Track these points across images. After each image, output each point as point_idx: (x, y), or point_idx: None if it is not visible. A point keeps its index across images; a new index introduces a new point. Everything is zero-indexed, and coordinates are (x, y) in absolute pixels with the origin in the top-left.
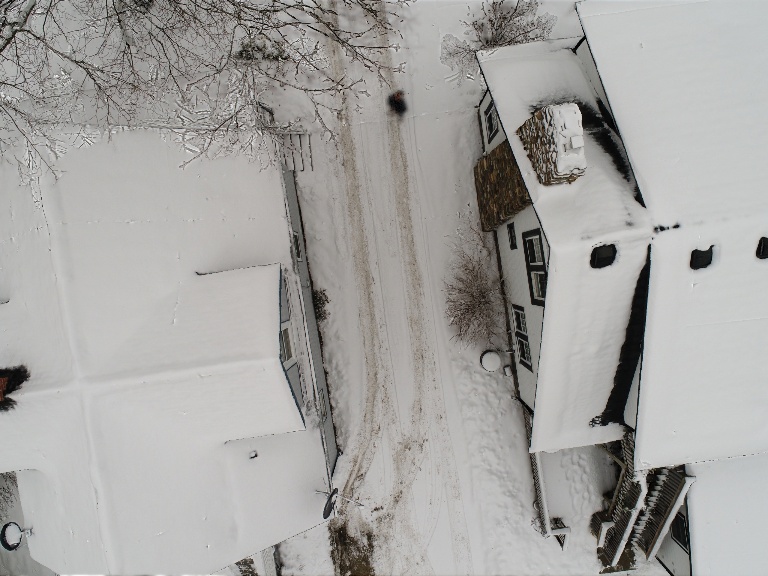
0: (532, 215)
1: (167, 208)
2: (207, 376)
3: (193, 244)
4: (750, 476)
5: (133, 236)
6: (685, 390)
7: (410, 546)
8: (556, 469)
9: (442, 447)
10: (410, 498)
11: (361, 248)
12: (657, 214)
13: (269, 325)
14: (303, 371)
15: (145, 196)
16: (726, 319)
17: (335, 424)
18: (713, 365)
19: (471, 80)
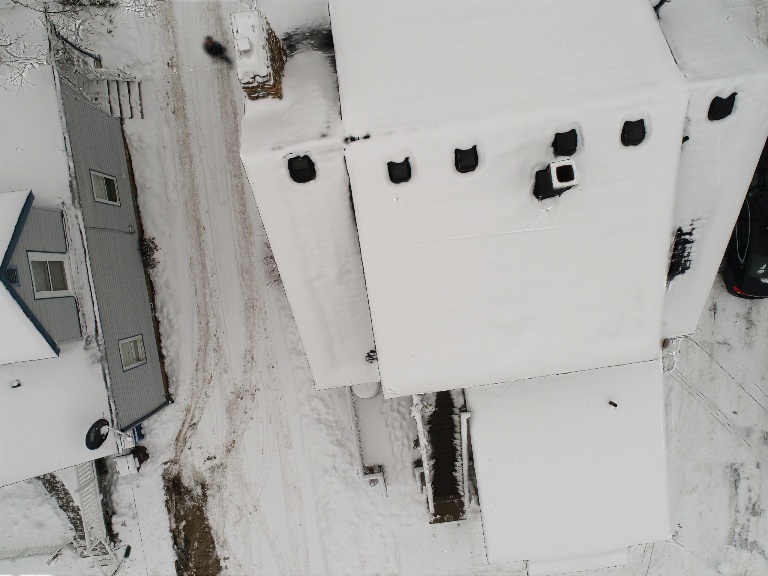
0: None
1: None
2: None
3: None
4: (530, 413)
5: None
6: (414, 312)
7: (242, 495)
8: (376, 416)
9: (274, 397)
10: (242, 447)
11: (192, 197)
12: (349, 125)
13: None
14: (83, 305)
15: None
16: (439, 237)
17: (167, 373)
18: (437, 286)
19: None
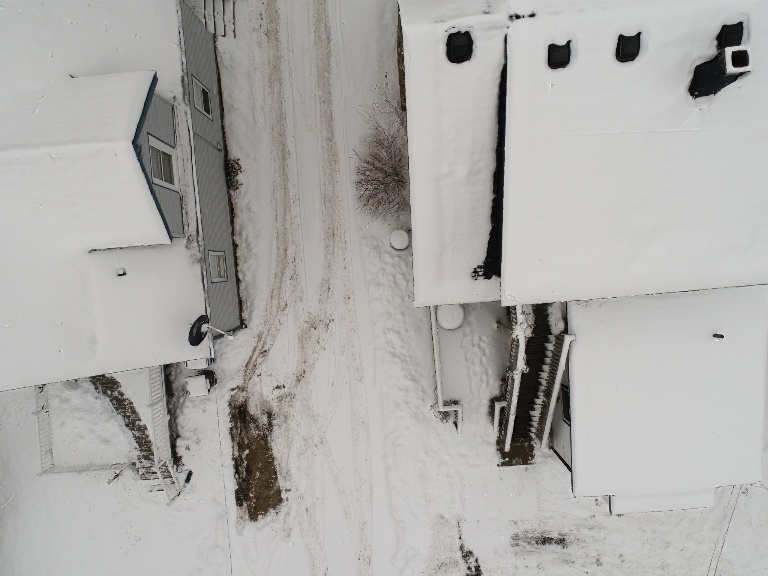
0: None
1: (42, 3)
2: (58, 158)
3: (69, 46)
4: (632, 341)
5: (0, 22)
6: (548, 212)
7: (309, 427)
8: (456, 350)
9: (348, 328)
10: (312, 378)
11: (279, 121)
12: (514, 2)
13: (128, 114)
14: (186, 204)
15: None
16: (587, 130)
17: (242, 298)
18: (576, 184)
19: None
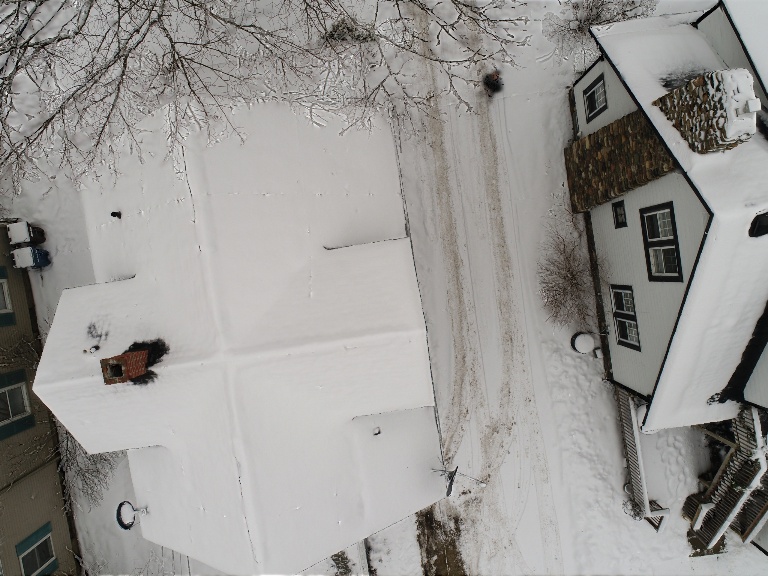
0: (659, 189)
1: (298, 181)
2: (352, 348)
3: (321, 218)
4: None
5: (269, 209)
6: None
7: (498, 530)
8: (651, 451)
9: (530, 430)
10: (498, 482)
11: (449, 230)
12: None
13: (411, 297)
14: None
15: (278, 169)
16: None
17: None
18: None
19: (564, 60)
